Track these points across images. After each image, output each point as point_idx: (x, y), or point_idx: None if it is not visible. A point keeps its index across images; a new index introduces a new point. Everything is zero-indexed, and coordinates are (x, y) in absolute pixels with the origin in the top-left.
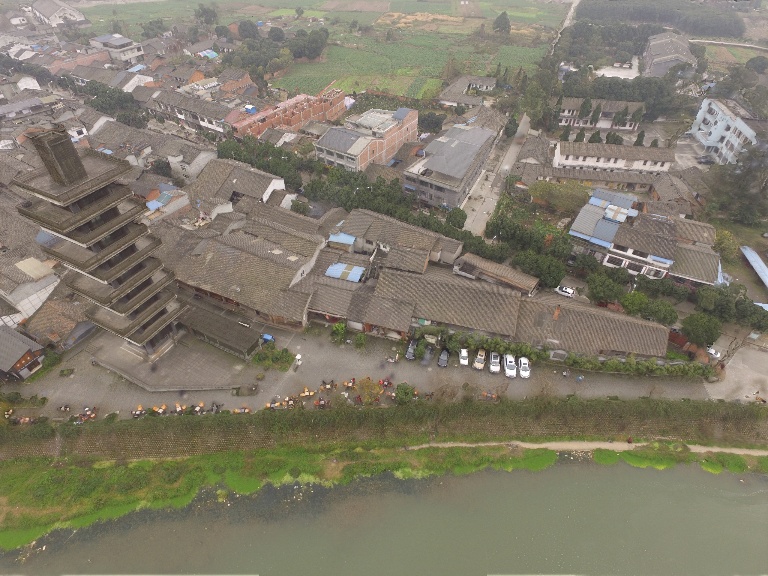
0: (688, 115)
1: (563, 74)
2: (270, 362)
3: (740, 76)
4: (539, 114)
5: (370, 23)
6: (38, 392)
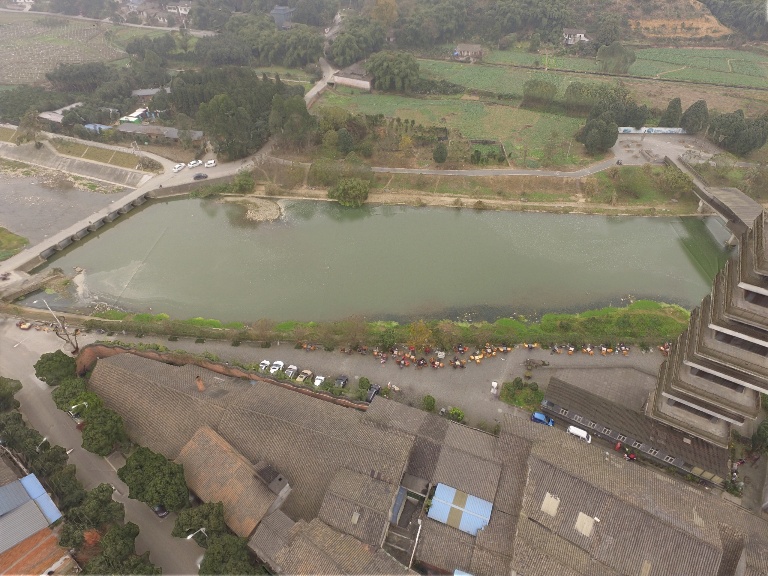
0: None
1: None
2: (525, 392)
3: None
4: None
5: None
6: None
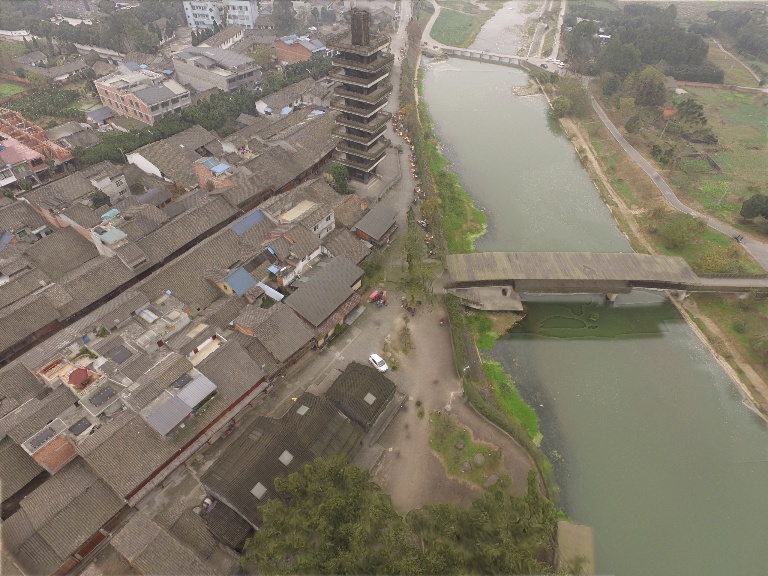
0: None
1: None
2: None
3: None
4: None
5: None
6: (402, 217)
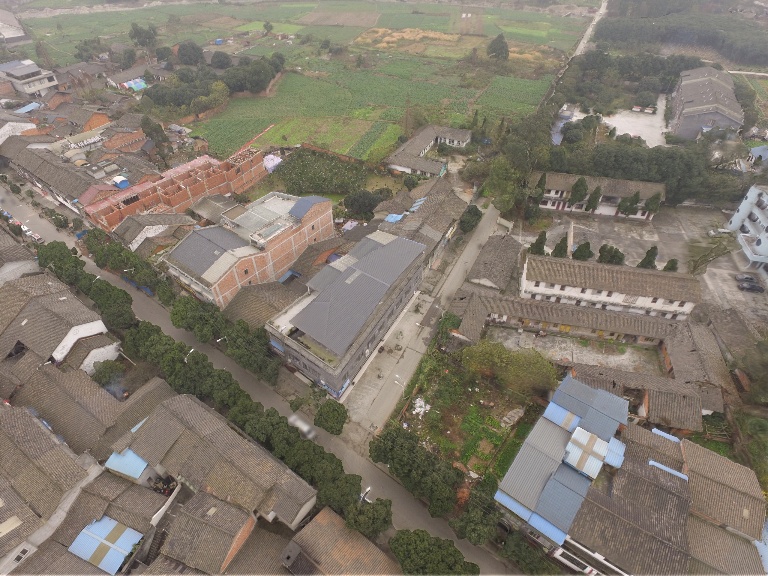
0: (727, 200)
1: (561, 125)
2: None
3: None
4: (507, 205)
5: (347, 42)
6: None
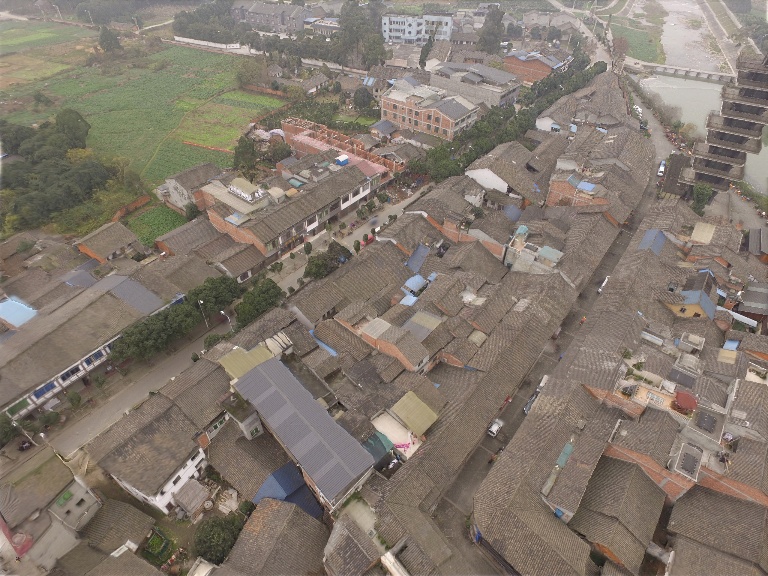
0: None
1: None
2: None
3: None
4: None
5: None
6: None
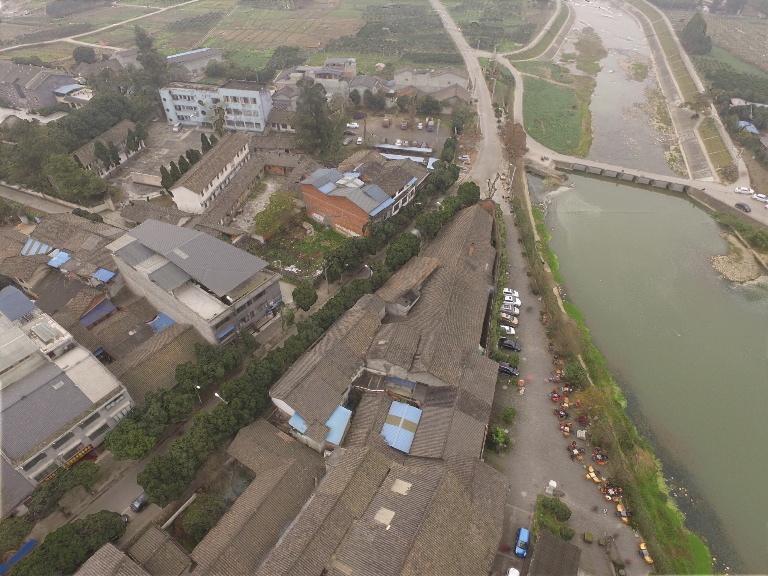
0: None
1: None
2: None
3: (154, 61)
4: (103, 183)
5: None
6: None
